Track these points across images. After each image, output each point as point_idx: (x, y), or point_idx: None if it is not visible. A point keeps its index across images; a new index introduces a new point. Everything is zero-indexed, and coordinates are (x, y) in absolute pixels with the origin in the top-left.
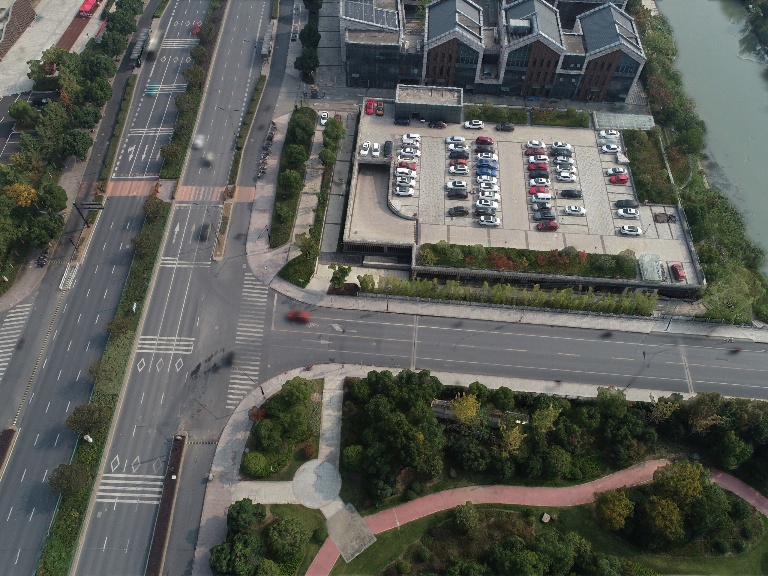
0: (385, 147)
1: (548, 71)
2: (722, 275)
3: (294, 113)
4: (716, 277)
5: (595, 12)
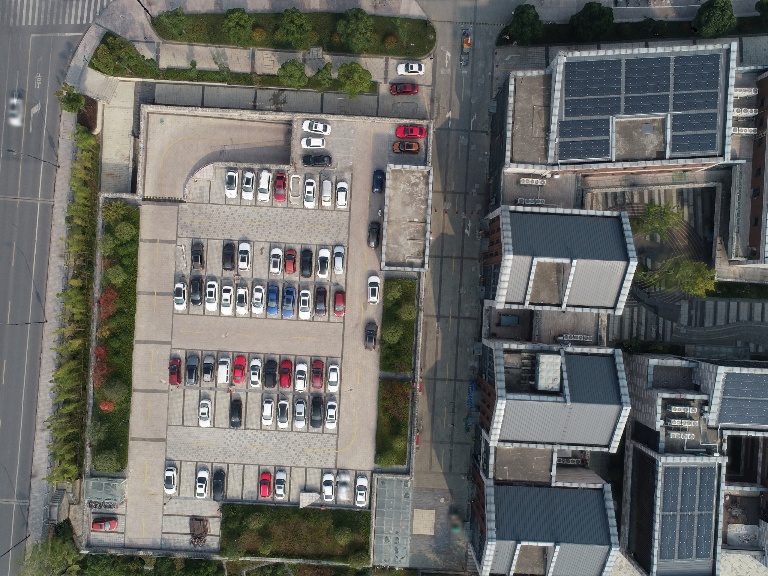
0: (316, 155)
1: (485, 416)
2: (92, 575)
3: (420, 21)
4: (88, 567)
5: (607, 517)
